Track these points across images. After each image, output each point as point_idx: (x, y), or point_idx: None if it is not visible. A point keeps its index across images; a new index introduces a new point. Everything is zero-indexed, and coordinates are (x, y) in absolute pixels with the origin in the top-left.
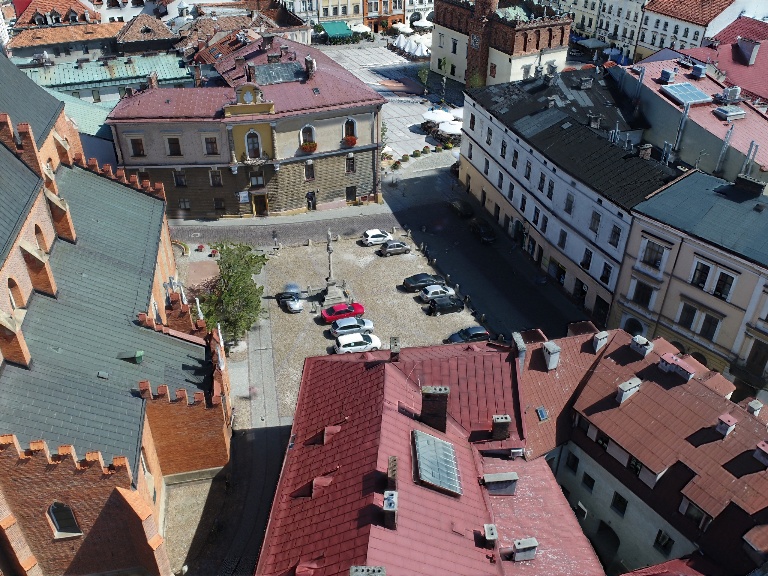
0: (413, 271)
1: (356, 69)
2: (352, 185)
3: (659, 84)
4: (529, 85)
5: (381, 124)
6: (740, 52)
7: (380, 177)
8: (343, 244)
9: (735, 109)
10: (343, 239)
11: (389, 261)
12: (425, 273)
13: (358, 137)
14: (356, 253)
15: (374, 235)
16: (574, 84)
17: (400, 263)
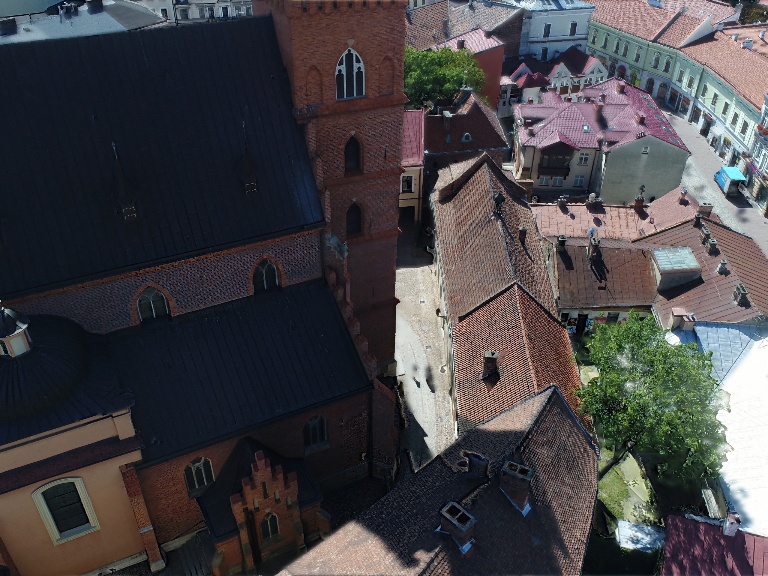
0: None
1: None
2: None
3: None
4: None
5: None
6: None
7: None
8: None
9: None
10: None
11: None
12: None
13: None
14: None
15: None
16: None
17: None
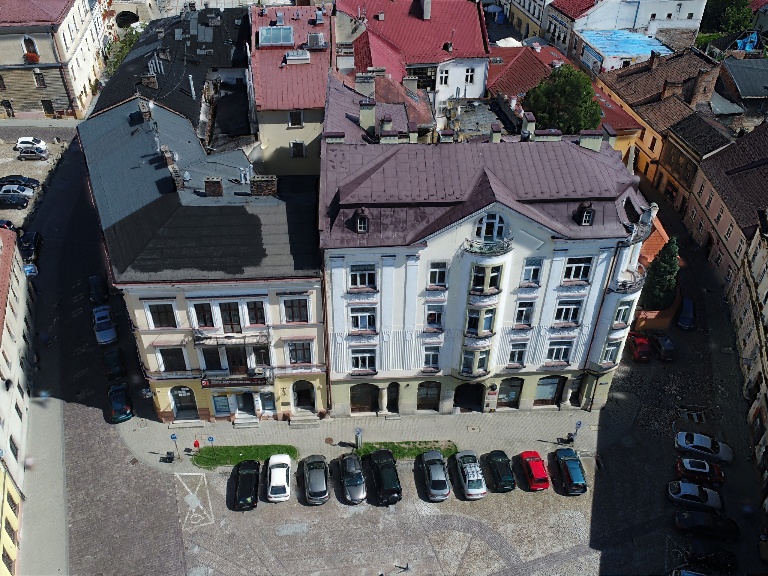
0: (28, 174)
1: (230, 6)
2: (47, 99)
3: (271, 26)
4: (178, 19)
5: (62, 45)
6: (420, 5)
7: (75, 95)
8: (2, 146)
9: (299, 54)
10: (7, 143)
11: (20, 164)
12: (21, 175)
13: (41, 55)
14: (2, 154)
15: (23, 141)
16: (207, 21)
17: (26, 167)
